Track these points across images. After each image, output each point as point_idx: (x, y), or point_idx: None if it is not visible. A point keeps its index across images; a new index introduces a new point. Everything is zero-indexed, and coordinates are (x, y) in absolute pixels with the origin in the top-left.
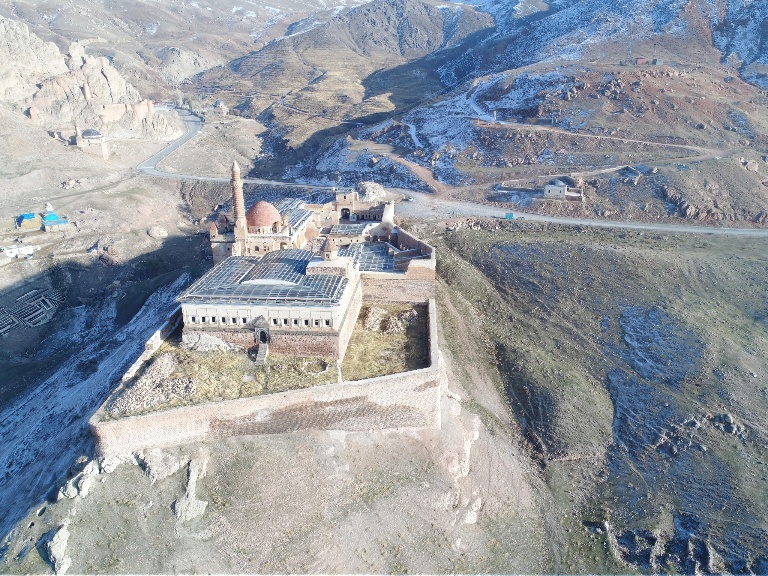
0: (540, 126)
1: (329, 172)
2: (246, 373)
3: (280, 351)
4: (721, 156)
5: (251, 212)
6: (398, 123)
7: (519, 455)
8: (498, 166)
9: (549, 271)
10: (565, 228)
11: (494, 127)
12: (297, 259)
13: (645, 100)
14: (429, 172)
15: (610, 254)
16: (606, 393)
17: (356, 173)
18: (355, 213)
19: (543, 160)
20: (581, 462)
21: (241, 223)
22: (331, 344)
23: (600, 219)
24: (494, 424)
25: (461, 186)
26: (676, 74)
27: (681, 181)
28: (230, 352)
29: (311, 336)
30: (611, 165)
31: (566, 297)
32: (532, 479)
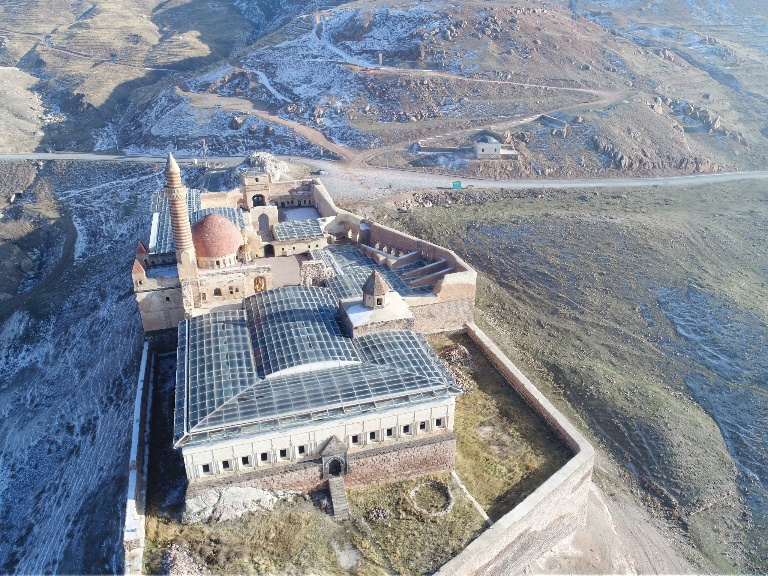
0: (427, 71)
1: (175, 138)
2: (334, 545)
3: (362, 481)
4: (622, 99)
5: (200, 235)
6: (241, 70)
7: (652, 519)
8: (400, 121)
9: (555, 255)
10: (519, 194)
11: (381, 73)
12: (312, 308)
13: (527, 39)
14: (318, 132)
15: (612, 226)
16: (698, 407)
17: (216, 138)
18: (272, 200)
19: (449, 111)
20: (718, 508)
21: (189, 256)
22: (444, 452)
23: (543, 179)
24: (609, 484)
25: (368, 149)
26: (540, 11)
27: (608, 130)
28: (280, 506)
29: (414, 448)
30: (523, 114)
31: (589, 287)
32: (683, 550)
